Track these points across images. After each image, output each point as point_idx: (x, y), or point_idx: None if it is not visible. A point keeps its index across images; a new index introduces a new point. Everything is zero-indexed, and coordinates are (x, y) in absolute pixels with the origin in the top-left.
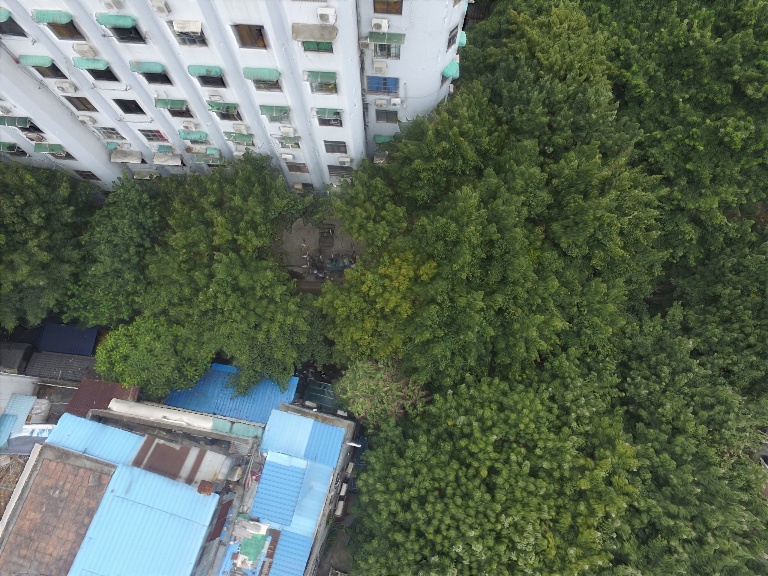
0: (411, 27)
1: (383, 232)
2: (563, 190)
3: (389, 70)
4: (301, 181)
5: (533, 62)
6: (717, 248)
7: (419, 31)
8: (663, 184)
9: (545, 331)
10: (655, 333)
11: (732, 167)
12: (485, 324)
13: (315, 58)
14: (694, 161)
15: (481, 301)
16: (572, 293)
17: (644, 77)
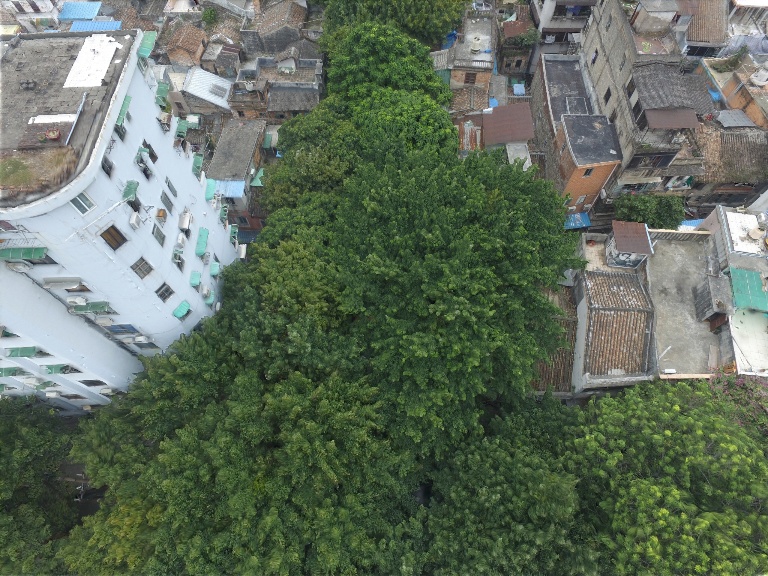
0: (106, 299)
1: (114, 477)
2: (282, 416)
3: (118, 321)
4: (87, 404)
5: (260, 293)
6: (456, 441)
7: (119, 298)
8: (399, 385)
9: (266, 570)
10: (391, 548)
11: (437, 373)
12: (208, 569)
13: (6, 342)
14: (413, 366)
15: (196, 548)
16: (305, 516)
17: (356, 297)
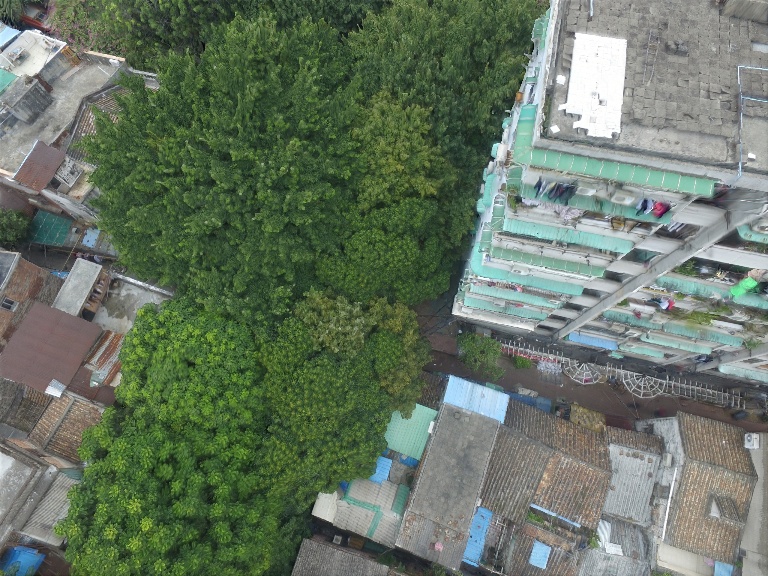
0: None
1: None
2: None
3: None
4: None
5: None
6: None
7: None
8: None
9: None
10: None
11: None
12: None
13: None
14: None
15: None
16: None
17: None
